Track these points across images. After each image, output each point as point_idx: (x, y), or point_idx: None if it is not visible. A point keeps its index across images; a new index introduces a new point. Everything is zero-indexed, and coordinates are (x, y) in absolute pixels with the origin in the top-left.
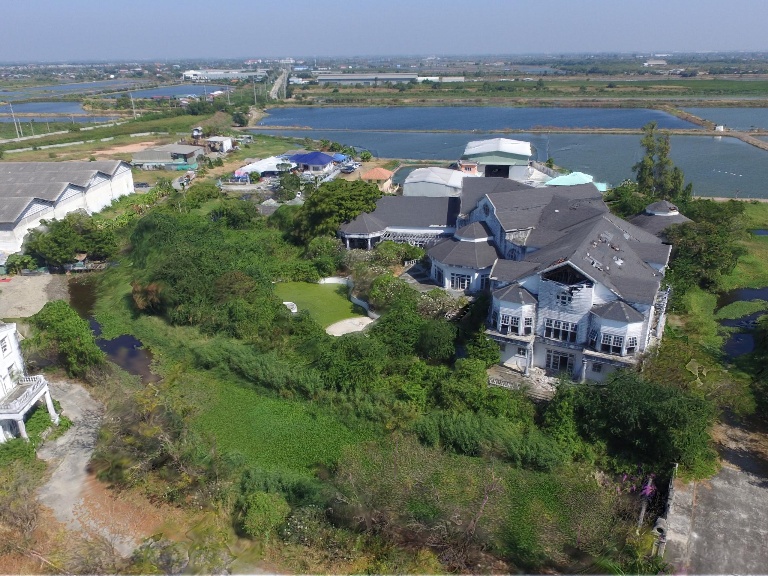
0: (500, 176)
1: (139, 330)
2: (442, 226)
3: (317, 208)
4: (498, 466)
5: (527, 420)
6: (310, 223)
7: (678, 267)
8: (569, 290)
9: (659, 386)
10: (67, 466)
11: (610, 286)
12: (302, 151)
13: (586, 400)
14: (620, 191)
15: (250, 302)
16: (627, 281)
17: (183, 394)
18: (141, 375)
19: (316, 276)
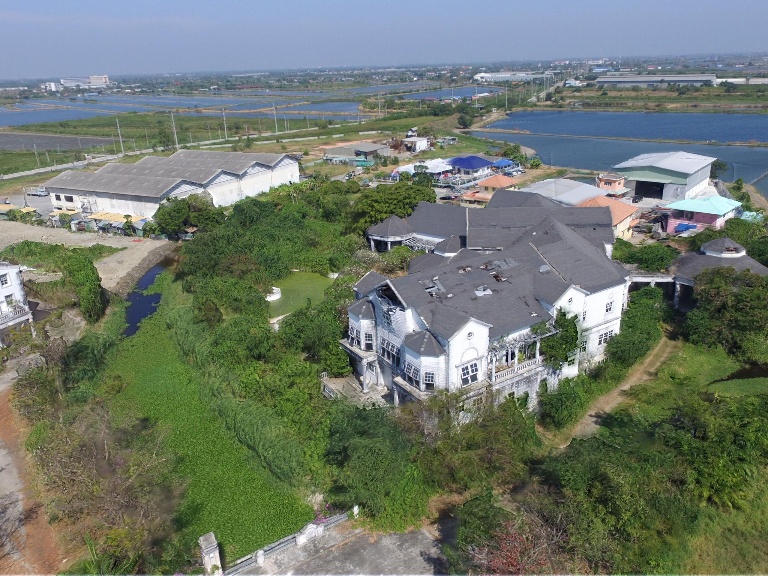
0: (656, 195)
1: (167, 291)
2: None
3: (355, 208)
4: (254, 462)
5: (302, 428)
6: (354, 221)
7: (690, 320)
8: (387, 310)
9: (394, 425)
10: (13, 373)
11: (423, 313)
12: (473, 155)
13: None
14: (730, 223)
15: (226, 281)
16: (447, 312)
17: (135, 344)
18: (130, 324)
19: (327, 270)
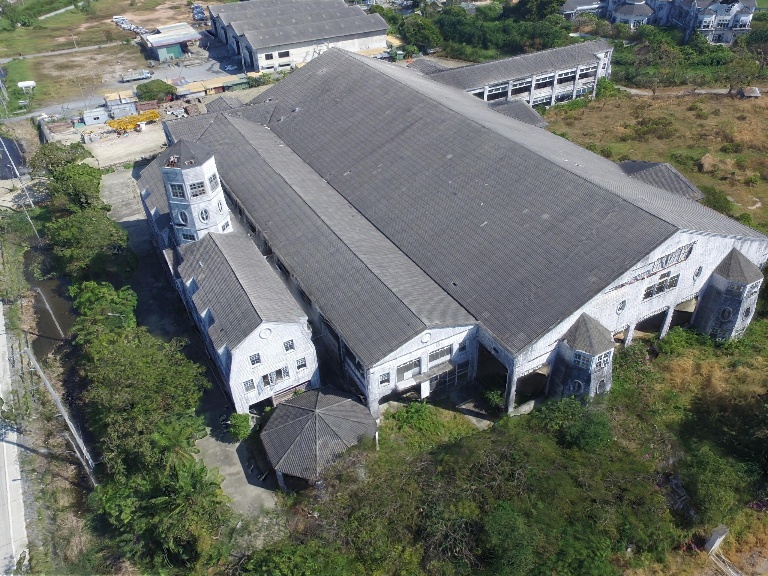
0: None
1: None
2: (599, 3)
3: None
4: None
5: None
6: (537, 9)
7: None
8: (732, 6)
9: None
10: None
11: None
12: None
13: None
14: None
15: None
16: (745, 1)
17: None
18: None
19: (567, 33)
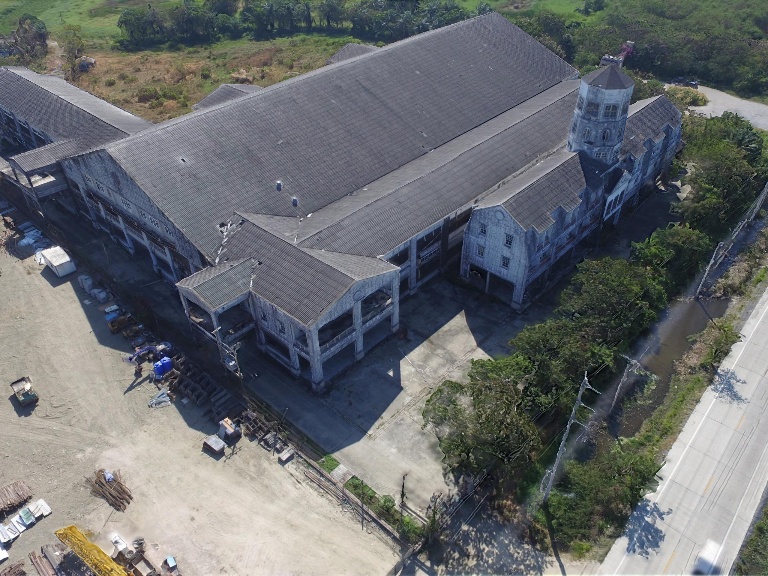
0: None
1: None
2: None
3: None
4: None
5: None
6: None
7: None
8: None
9: None
10: None
11: None
12: None
13: None
14: None
15: None
16: None
17: None
18: None
19: None
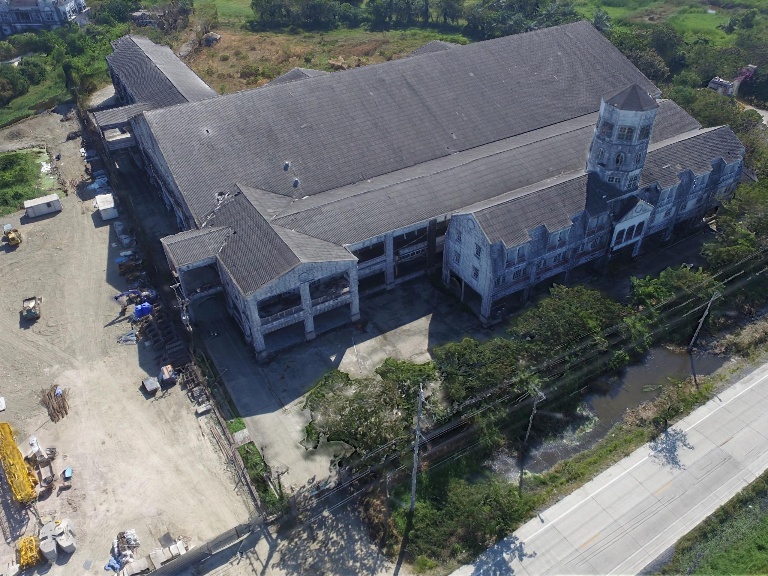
0: None
1: None
2: None
3: None
4: None
5: None
6: None
7: None
8: None
9: None
10: None
11: None
12: None
13: (110, 14)
14: None
15: None
16: None
17: None
18: None
19: None
